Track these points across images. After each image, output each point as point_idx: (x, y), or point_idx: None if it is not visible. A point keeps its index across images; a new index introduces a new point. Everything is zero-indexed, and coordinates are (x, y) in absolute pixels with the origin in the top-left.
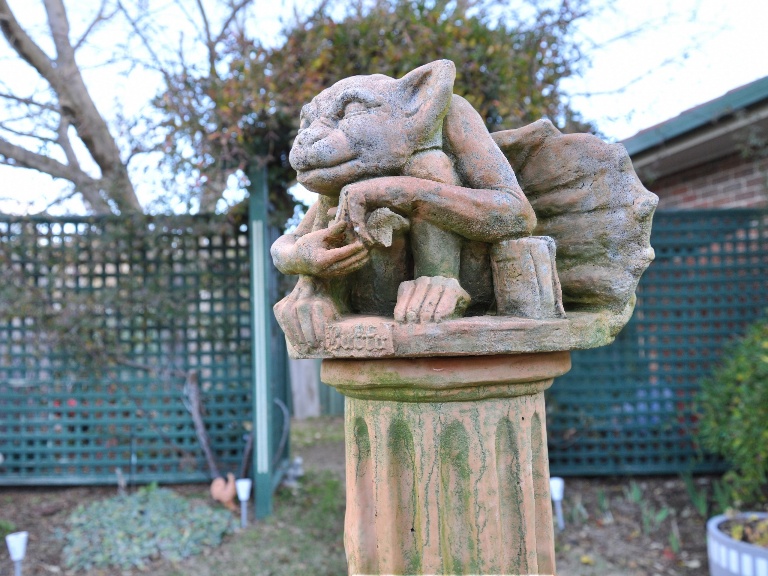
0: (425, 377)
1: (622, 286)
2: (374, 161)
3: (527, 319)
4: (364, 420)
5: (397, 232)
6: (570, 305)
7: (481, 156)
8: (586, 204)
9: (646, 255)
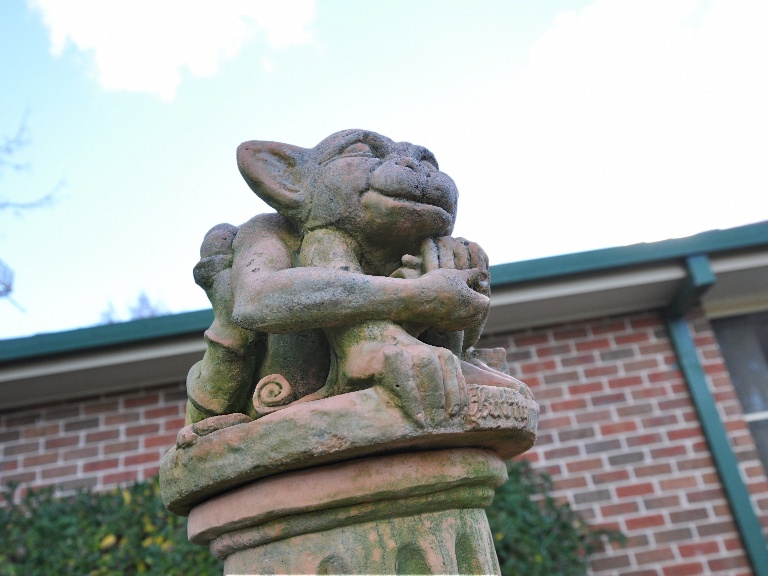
0: None
1: None
2: None
3: None
4: (417, 546)
5: None
6: None
7: None
8: None
9: None
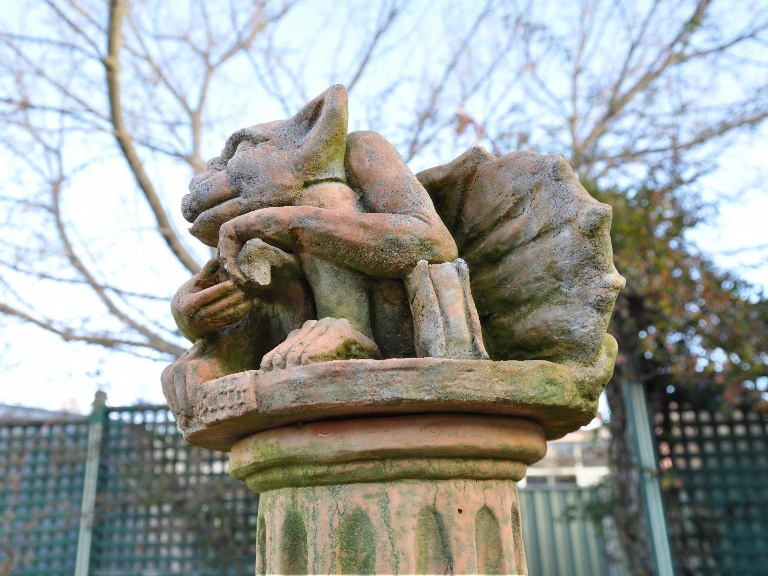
0: (308, 445)
1: (583, 325)
2: (257, 196)
3: None
4: None
5: (282, 271)
6: None
7: (385, 182)
8: (528, 231)
9: (608, 281)
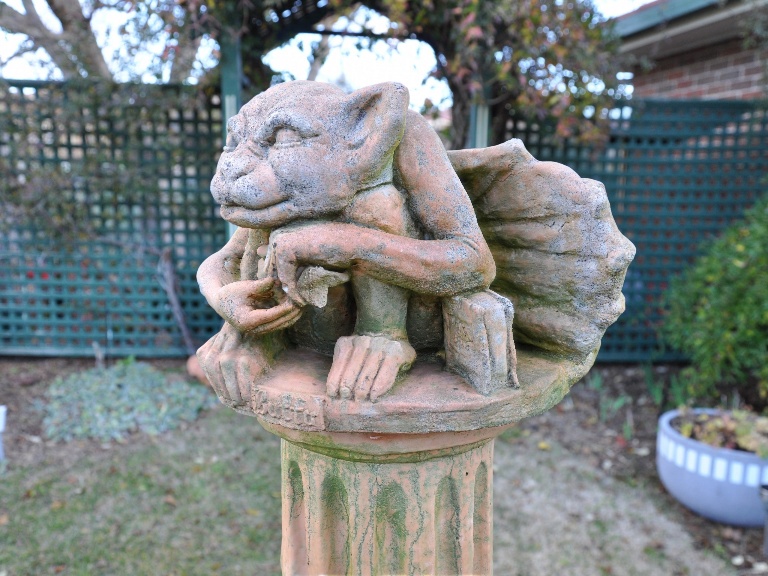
0: (361, 445)
1: (586, 339)
2: (309, 205)
3: (474, 396)
4: None
5: (334, 286)
6: (529, 346)
7: (436, 196)
8: (555, 246)
9: (615, 309)
